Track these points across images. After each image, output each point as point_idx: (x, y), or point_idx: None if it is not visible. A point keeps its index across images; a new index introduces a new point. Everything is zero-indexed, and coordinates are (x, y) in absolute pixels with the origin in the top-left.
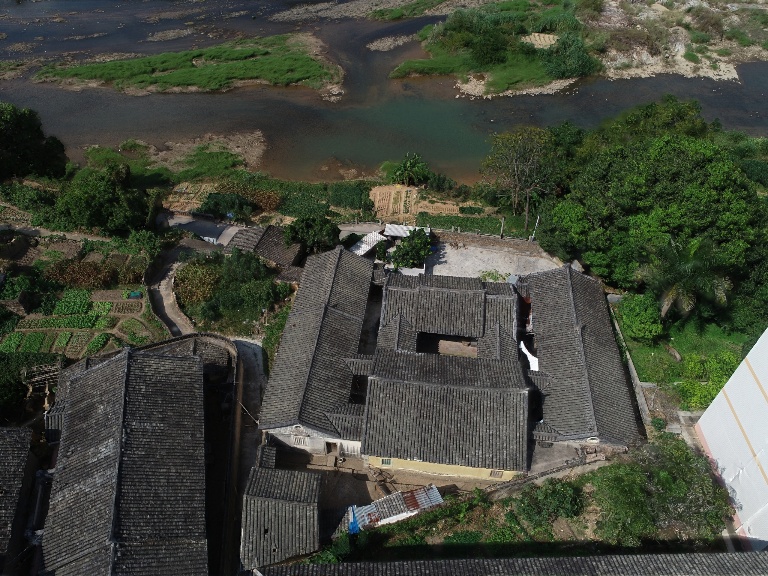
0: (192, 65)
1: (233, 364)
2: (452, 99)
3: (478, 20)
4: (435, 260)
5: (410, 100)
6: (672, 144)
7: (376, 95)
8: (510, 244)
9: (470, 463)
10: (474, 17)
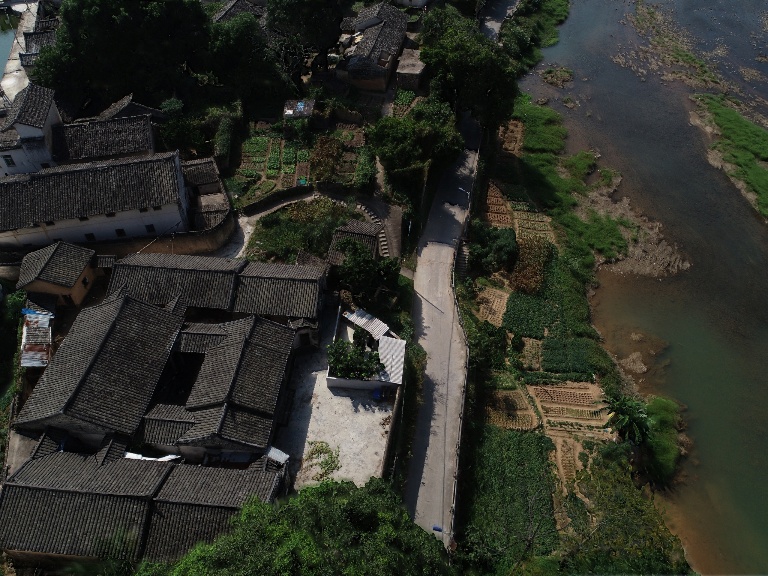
0: None
1: None
2: None
3: None
4: (360, 399)
5: None
6: (288, 558)
7: None
8: None
9: (40, 382)
10: None
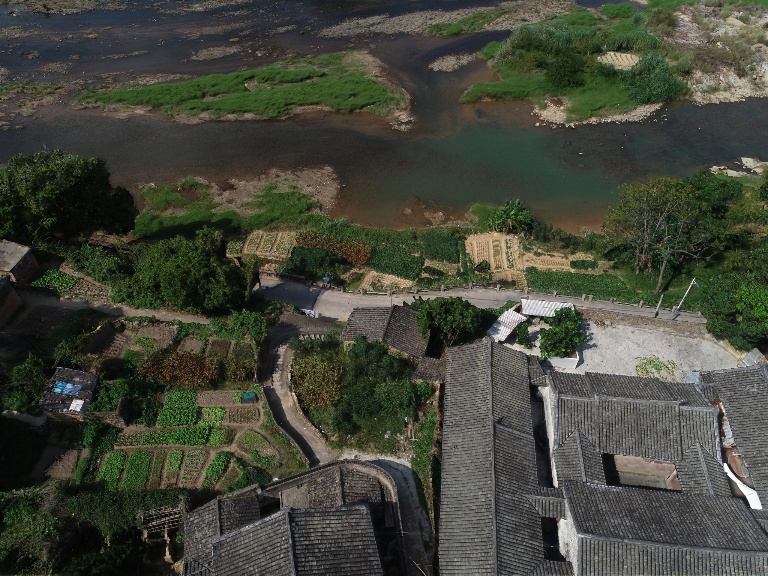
0: (245, 89)
1: (386, 497)
2: (532, 128)
3: (547, 37)
4: (582, 343)
5: (486, 129)
6: None
7: (449, 123)
8: (668, 324)
9: None
10: (542, 34)
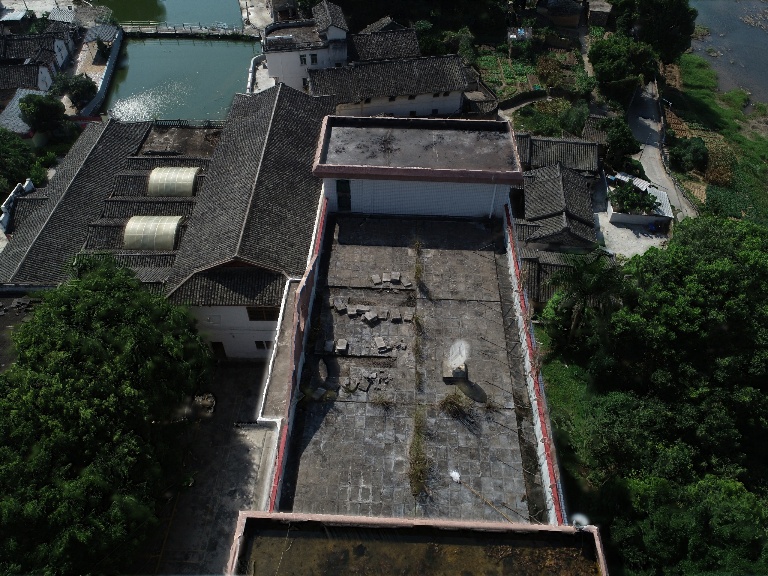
0: None
1: None
2: None
3: None
4: (638, 230)
5: None
6: None
7: None
8: None
9: None
10: None
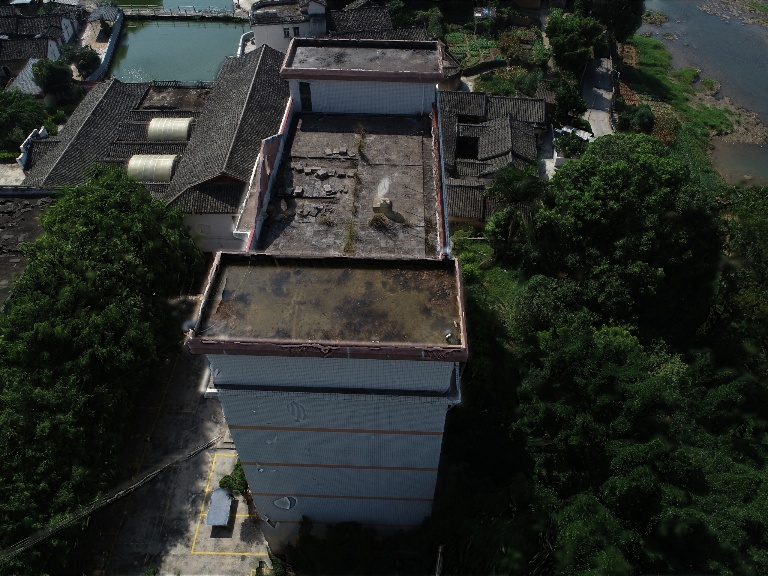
0: None
1: None
2: None
3: None
4: None
5: None
6: None
7: None
8: None
9: None
10: None
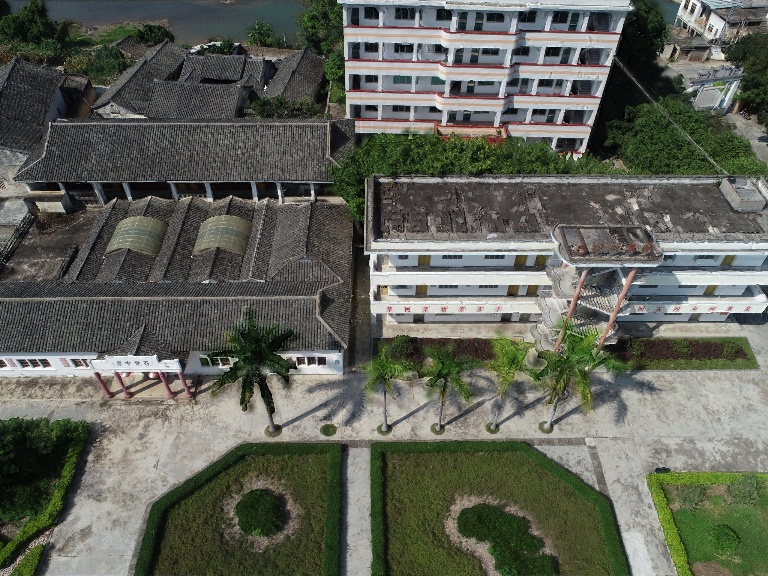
0: None
1: None
2: None
3: None
4: None
5: (287, 3)
6: None
7: (262, 0)
8: (290, 52)
9: None
10: None
